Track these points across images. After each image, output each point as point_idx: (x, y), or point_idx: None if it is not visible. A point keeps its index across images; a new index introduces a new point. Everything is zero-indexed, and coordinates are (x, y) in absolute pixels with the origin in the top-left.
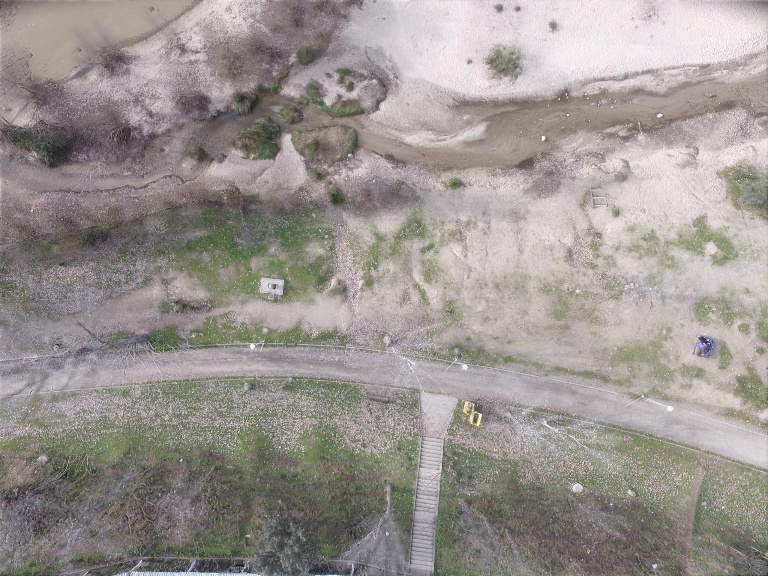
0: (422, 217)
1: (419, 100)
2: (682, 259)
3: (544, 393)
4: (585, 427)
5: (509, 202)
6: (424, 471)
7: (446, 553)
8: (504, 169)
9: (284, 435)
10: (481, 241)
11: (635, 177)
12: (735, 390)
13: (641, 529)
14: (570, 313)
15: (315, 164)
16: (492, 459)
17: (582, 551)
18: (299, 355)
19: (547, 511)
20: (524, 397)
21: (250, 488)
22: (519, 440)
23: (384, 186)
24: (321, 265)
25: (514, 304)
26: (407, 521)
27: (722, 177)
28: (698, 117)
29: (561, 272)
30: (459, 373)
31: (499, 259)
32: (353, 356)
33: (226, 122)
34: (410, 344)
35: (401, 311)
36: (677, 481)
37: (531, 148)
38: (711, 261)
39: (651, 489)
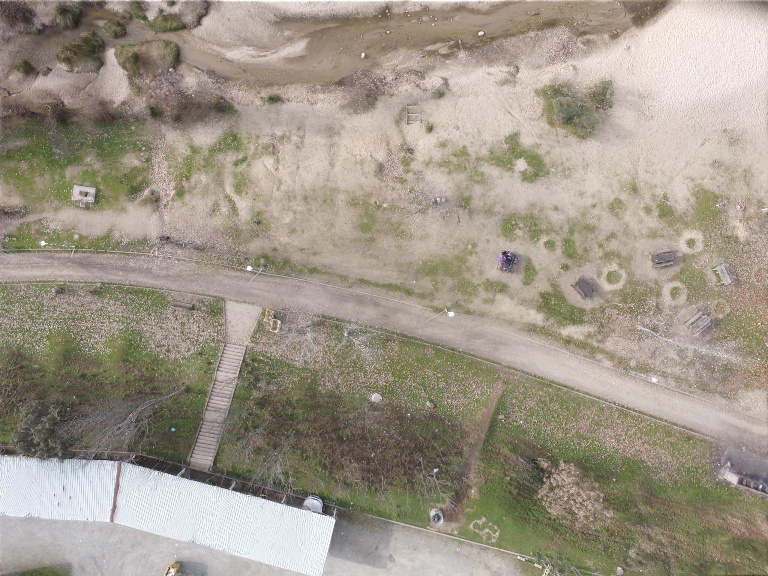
0: (238, 131)
1: (240, 15)
2: (492, 175)
3: (348, 305)
4: (387, 339)
5: (325, 118)
6: (221, 375)
7: (228, 449)
8: (324, 86)
9: (92, 338)
10: (293, 155)
11: (452, 94)
12: (538, 306)
13: (433, 438)
14: (376, 226)
15: (137, 78)
16: (293, 367)
17: (366, 454)
18: (109, 261)
19: (341, 417)
20: (328, 308)
21: (50, 385)
22: (321, 350)
23: (203, 100)
24: (136, 176)
25: (321, 216)
26: (196, 419)
27: (540, 96)
28: (520, 35)
29: (370, 186)
30: (264, 283)
31: (309, 172)
32: (161, 264)
33: (51, 36)
34: (217, 253)
35: (210, 221)
36: (476, 394)
37: (351, 65)
38: (521, 178)
39: (450, 401)
